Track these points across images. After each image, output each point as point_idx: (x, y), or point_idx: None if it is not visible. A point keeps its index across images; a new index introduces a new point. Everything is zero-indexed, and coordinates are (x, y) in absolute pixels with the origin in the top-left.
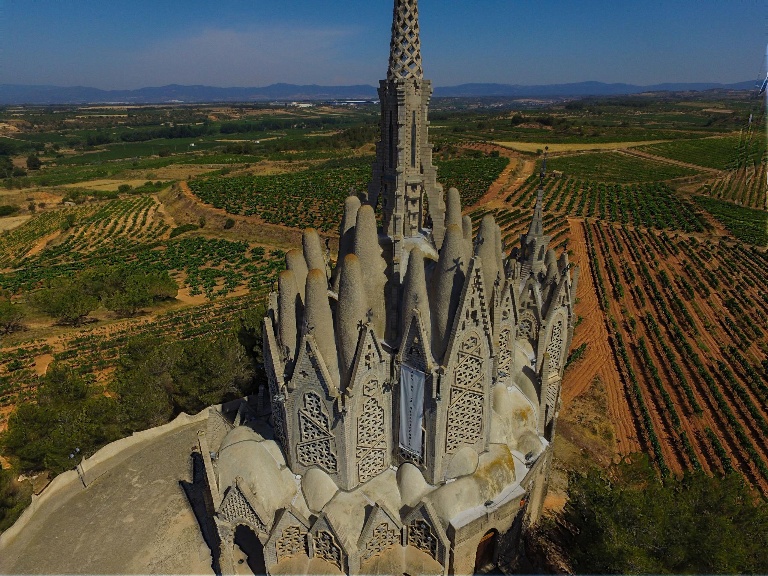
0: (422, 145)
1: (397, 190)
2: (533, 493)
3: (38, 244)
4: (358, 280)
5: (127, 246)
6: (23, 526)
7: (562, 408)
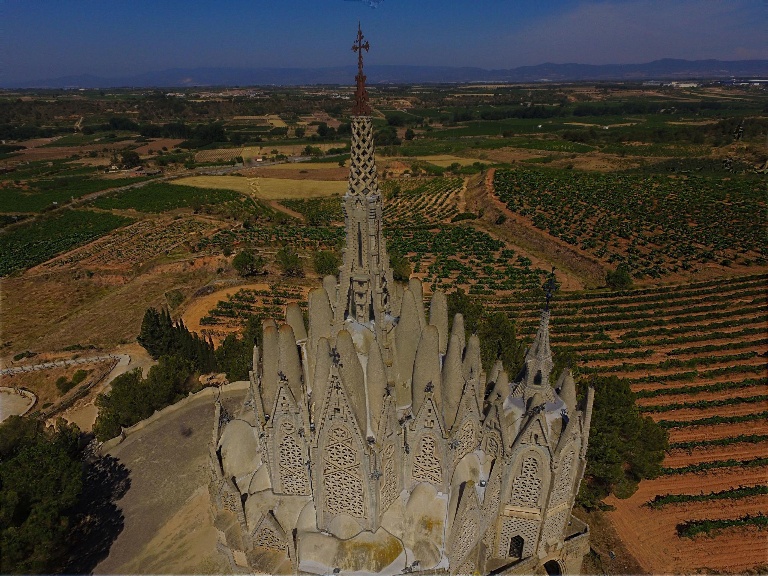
0: (368, 251)
1: (340, 284)
2: None
3: None
4: (284, 346)
5: (418, 222)
6: (180, 407)
7: (668, 567)
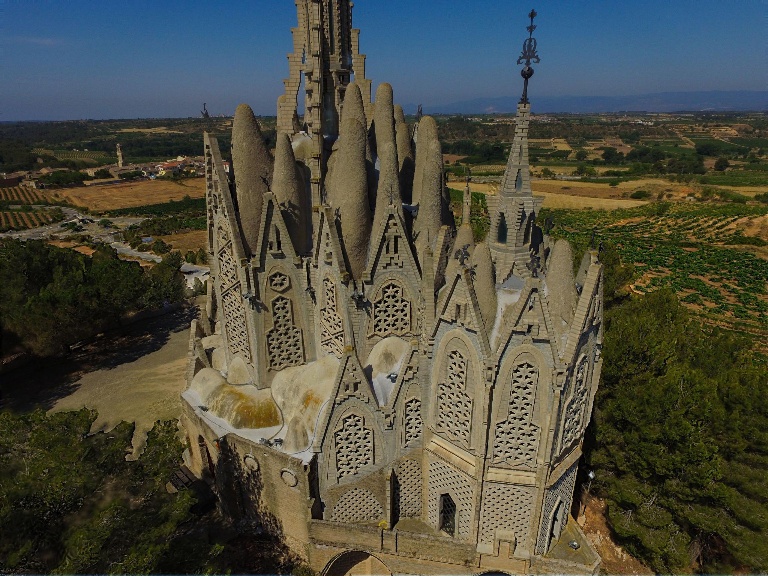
0: None
1: None
2: (274, 491)
3: (622, 222)
4: None
5: None
6: None
7: None
